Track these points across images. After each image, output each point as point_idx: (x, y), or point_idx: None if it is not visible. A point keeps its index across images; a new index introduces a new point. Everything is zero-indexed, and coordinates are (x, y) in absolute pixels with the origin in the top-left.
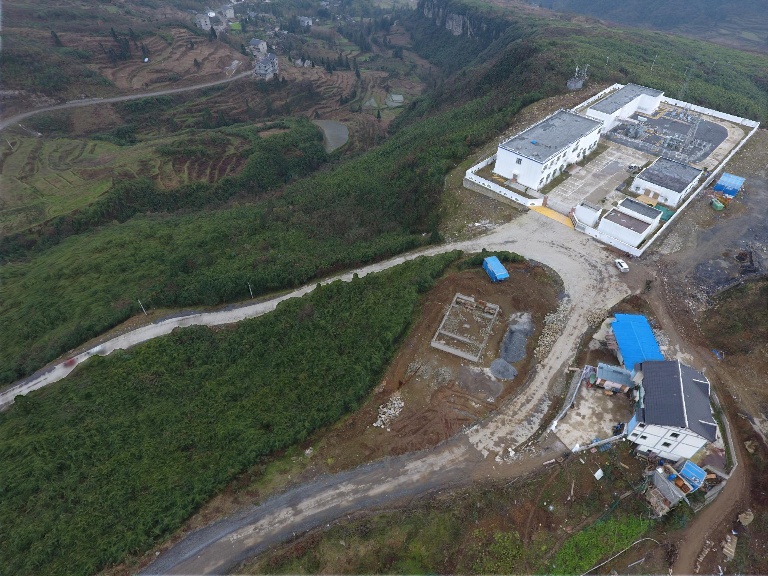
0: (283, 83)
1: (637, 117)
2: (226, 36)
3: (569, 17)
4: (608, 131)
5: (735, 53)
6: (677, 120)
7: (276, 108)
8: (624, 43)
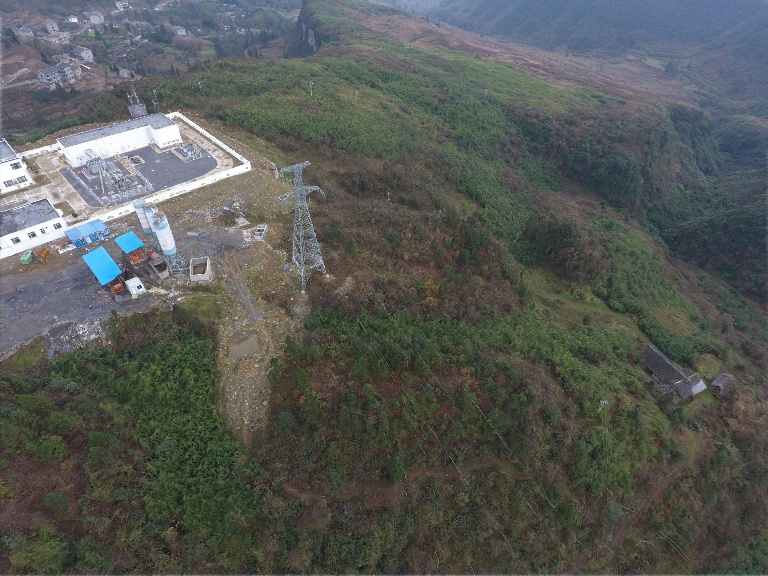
0: (72, 93)
1: (143, 150)
2: (39, 43)
3: (417, 37)
4: (66, 165)
5: (519, 81)
6: (178, 155)
7: (52, 119)
8: (367, 67)
